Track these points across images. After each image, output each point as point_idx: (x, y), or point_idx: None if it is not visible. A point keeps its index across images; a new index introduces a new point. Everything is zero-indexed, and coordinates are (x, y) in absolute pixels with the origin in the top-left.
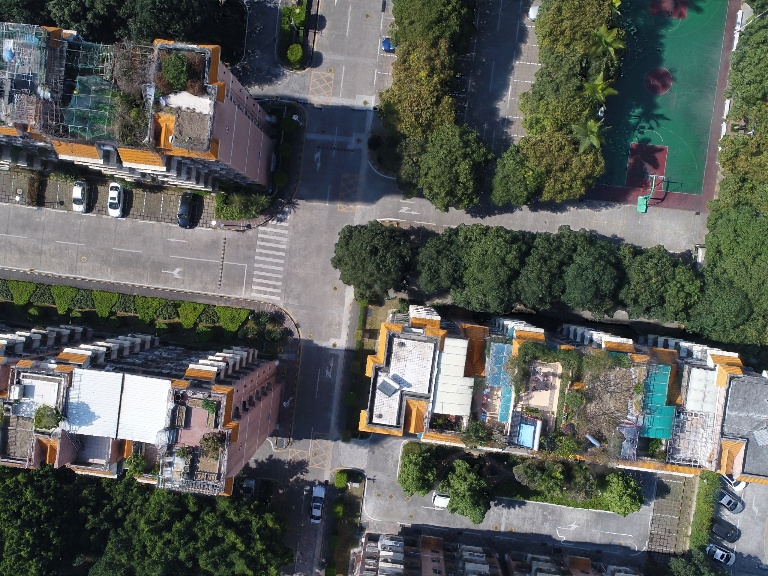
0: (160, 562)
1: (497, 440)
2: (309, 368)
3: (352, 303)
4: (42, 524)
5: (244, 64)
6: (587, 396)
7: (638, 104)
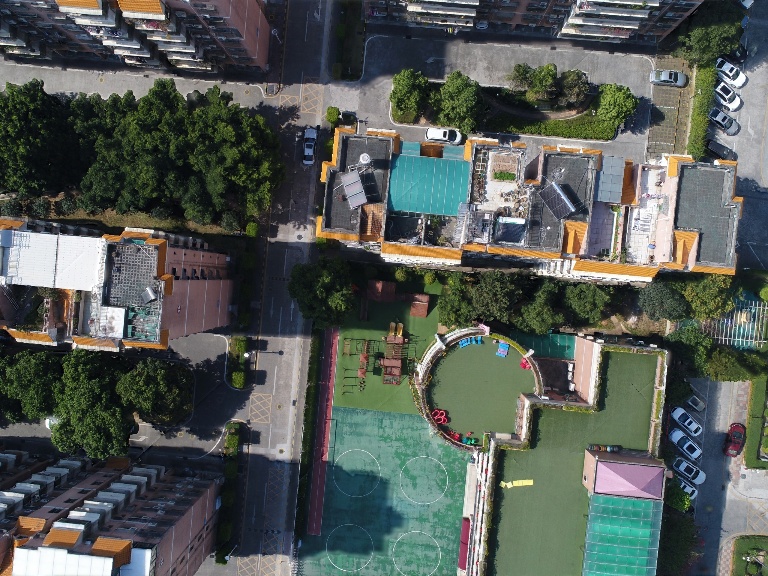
0: (150, 153)
1: None
2: (297, 11)
3: None
4: (30, 116)
5: None
6: None
7: None
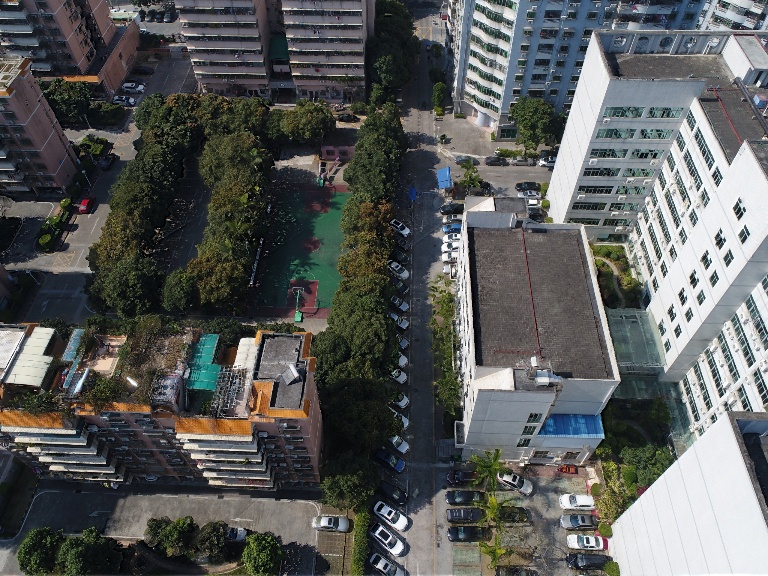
0: None
1: (60, 406)
2: None
3: None
4: None
5: (8, 251)
6: (141, 356)
7: (296, 258)
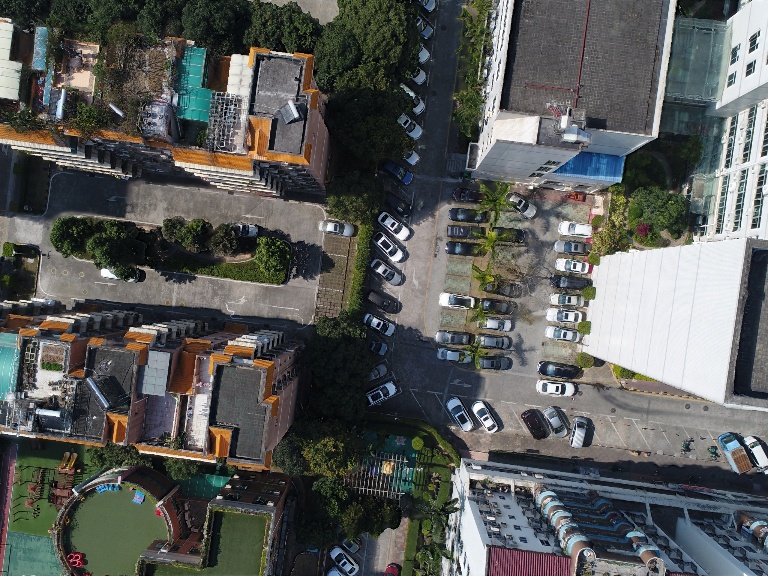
0: None
1: (46, 126)
2: None
3: None
4: None
5: None
6: (120, 73)
7: None
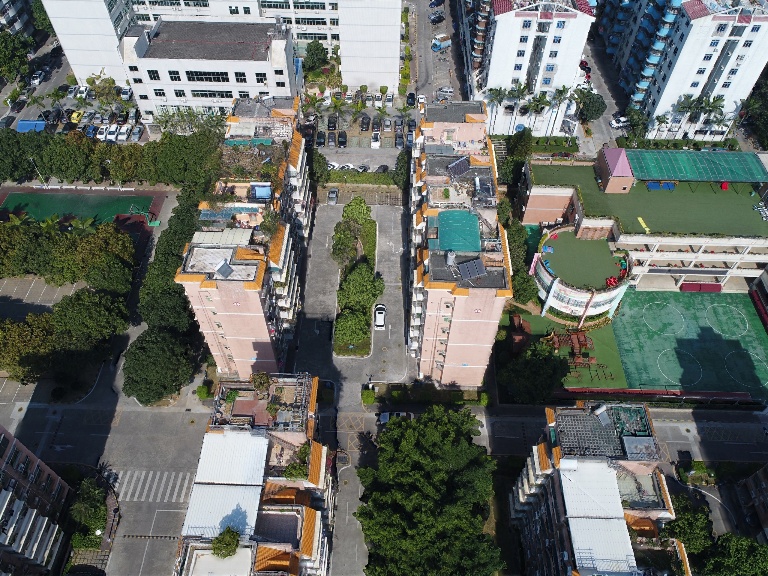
0: None
1: None
2: None
3: (207, 406)
4: None
5: None
6: None
7: None
